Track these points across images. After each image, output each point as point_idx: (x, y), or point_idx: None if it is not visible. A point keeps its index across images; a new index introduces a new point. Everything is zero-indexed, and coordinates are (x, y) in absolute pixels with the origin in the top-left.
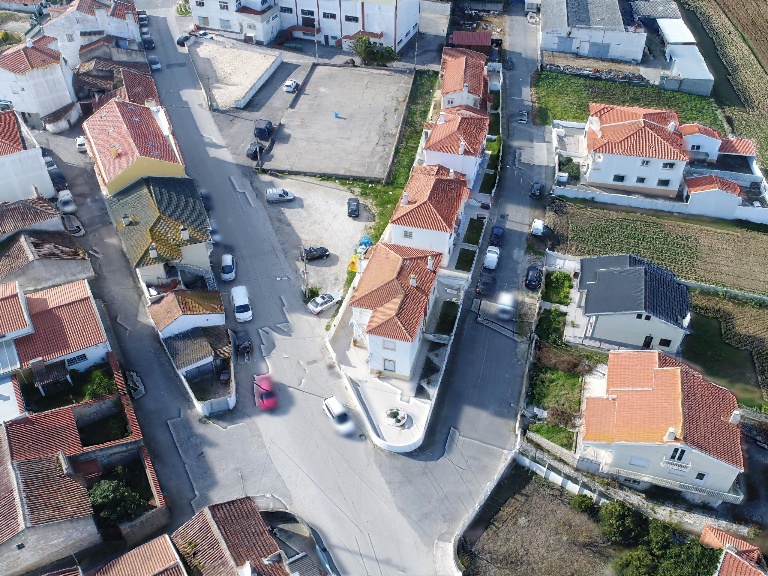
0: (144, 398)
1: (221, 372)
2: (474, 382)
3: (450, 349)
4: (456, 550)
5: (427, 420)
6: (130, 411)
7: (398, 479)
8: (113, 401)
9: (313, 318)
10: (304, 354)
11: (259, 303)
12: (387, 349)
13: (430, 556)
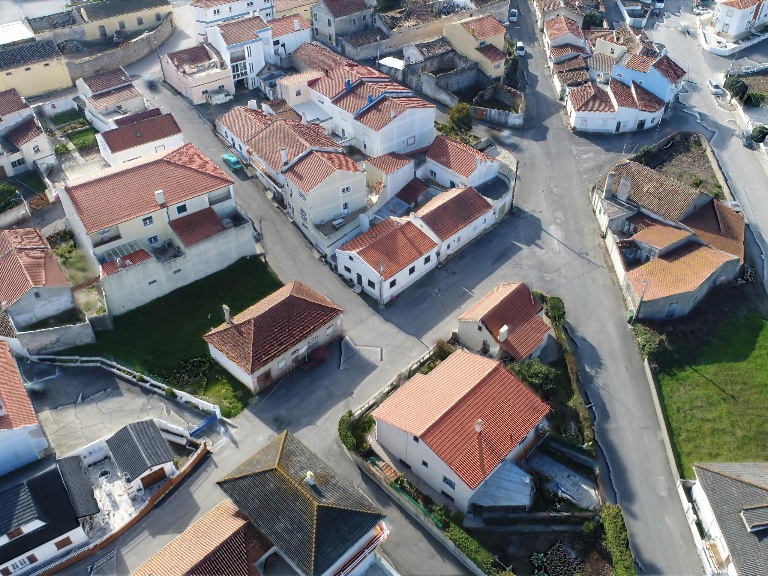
0: (605, 15)
1: (642, 17)
2: (767, 50)
3: (762, 40)
4: (726, 71)
5: (735, 48)
6: (603, 6)
7: (710, 58)
8: (596, 4)
9: (694, 15)
10: (684, 22)
11: (669, 5)
12: (728, 16)
13: (713, 74)
